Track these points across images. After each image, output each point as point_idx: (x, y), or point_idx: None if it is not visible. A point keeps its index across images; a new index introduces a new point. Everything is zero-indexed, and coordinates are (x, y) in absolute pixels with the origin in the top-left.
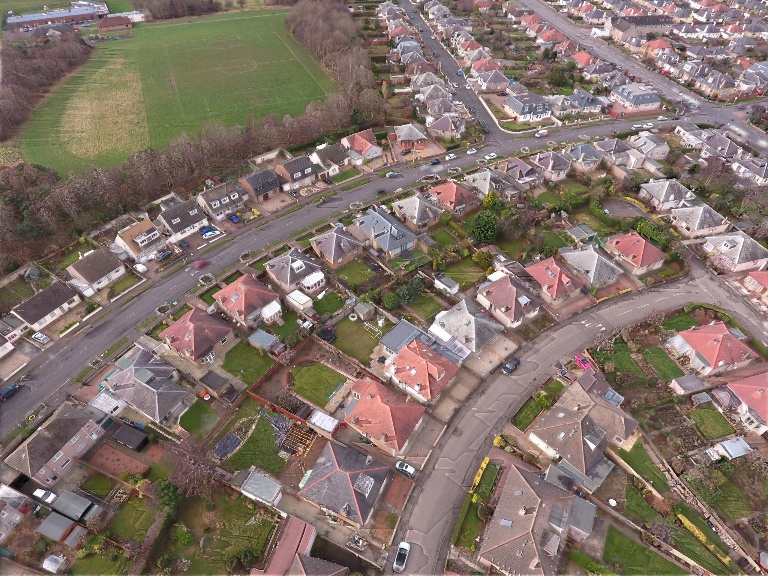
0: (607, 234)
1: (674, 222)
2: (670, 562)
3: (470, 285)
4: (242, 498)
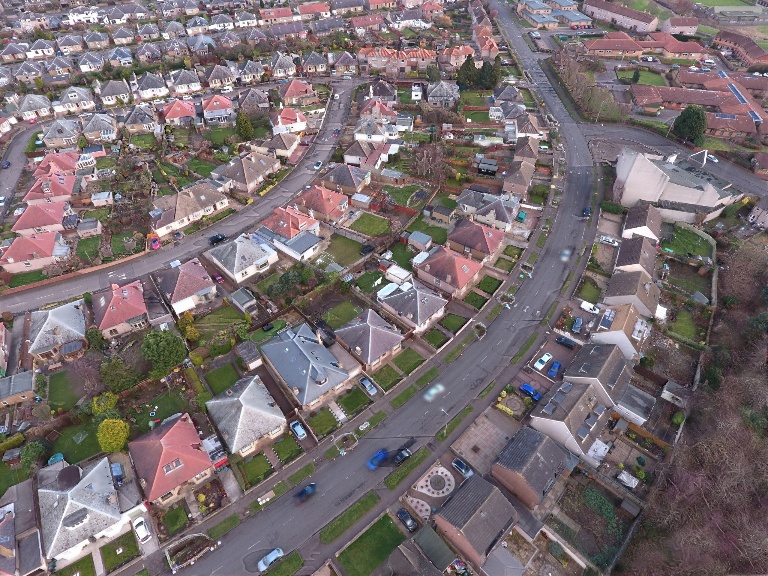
0: None
1: None
2: None
3: (217, 310)
4: None
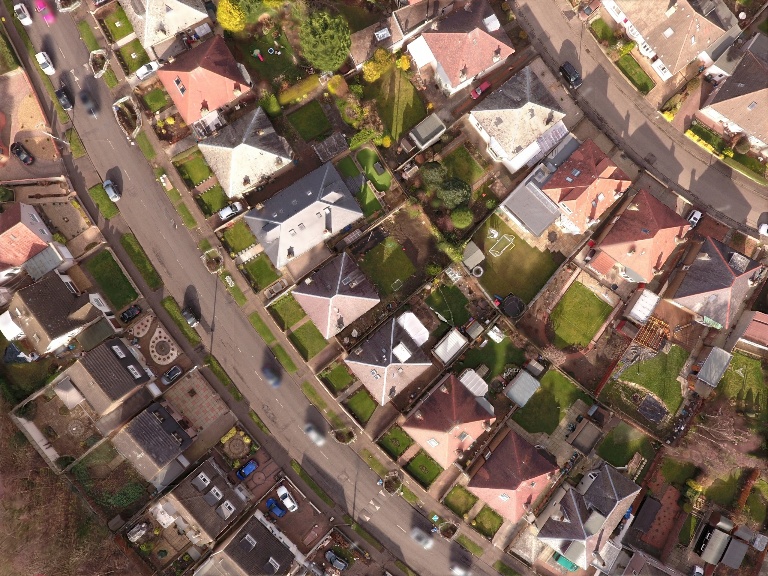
0: None
1: None
2: None
3: (421, 98)
4: None
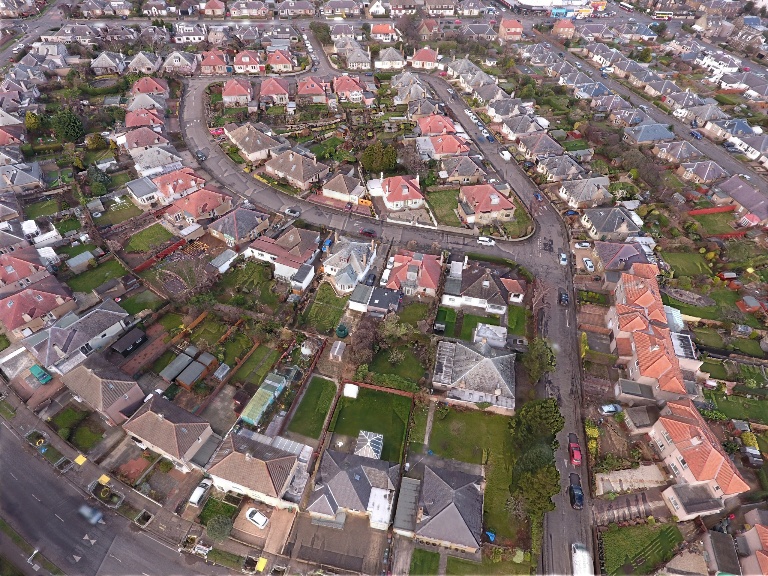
0: (122, 96)
1: (137, 72)
2: (329, 140)
3: None
4: (224, 274)
